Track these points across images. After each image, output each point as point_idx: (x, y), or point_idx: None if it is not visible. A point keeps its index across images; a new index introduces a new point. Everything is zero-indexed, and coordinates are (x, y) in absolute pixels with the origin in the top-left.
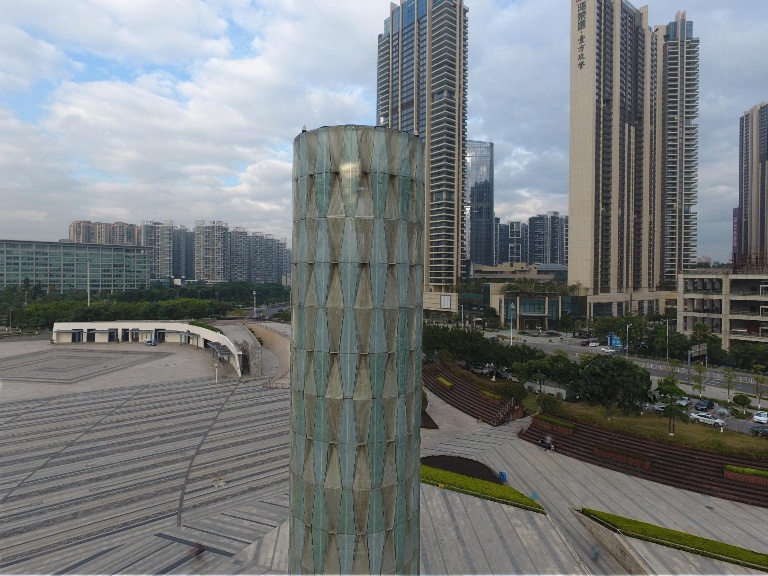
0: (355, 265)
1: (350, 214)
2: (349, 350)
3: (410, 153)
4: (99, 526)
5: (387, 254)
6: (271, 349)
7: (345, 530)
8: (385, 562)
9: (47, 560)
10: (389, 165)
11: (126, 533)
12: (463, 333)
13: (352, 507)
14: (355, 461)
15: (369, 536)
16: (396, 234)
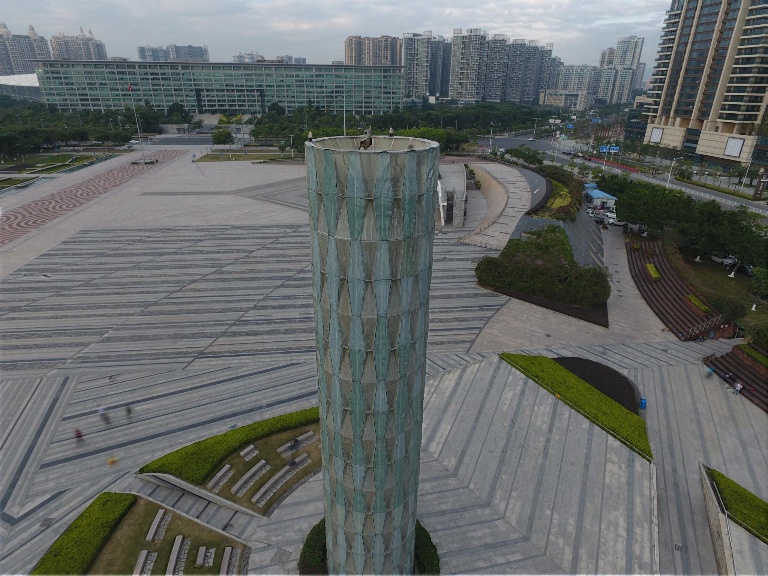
0: (337, 278)
1: (332, 234)
2: (336, 341)
3: (398, 169)
4: (296, 344)
5: (364, 272)
6: (486, 195)
7: (339, 455)
8: (367, 483)
9: (263, 359)
10: (368, 187)
11: (309, 354)
12: (707, 212)
13: (341, 444)
14: (342, 417)
15: (353, 465)
16: (374, 254)
